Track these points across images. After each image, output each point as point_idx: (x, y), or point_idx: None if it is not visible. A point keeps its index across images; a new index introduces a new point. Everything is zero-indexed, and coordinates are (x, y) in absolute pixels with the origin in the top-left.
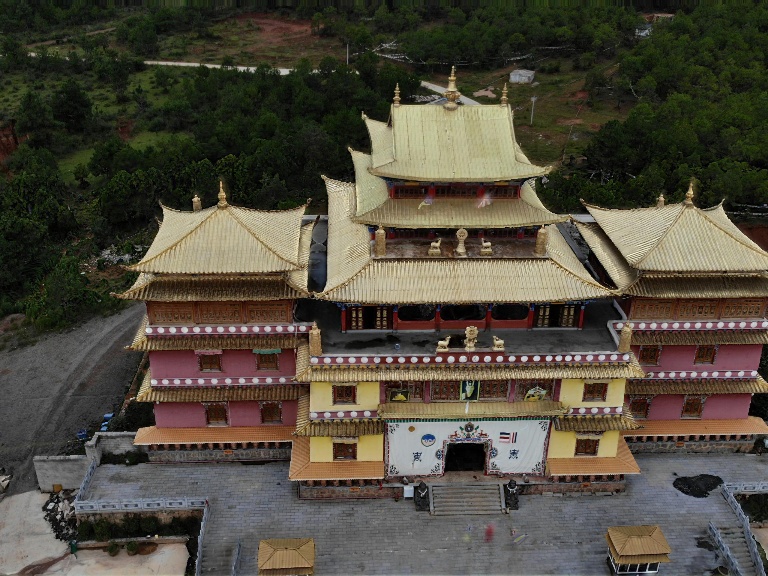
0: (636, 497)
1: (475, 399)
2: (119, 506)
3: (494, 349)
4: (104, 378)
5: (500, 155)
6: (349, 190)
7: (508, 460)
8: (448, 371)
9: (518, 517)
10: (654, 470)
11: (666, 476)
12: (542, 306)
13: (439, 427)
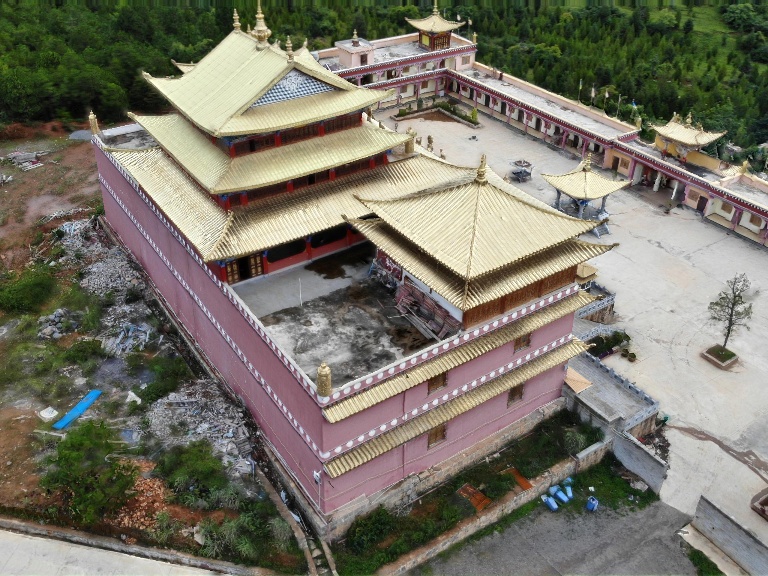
0: None
1: None
2: (627, 385)
3: None
4: (510, 568)
5: (298, 58)
6: (243, 226)
7: None
8: None
9: None
10: None
11: None
12: None
13: None
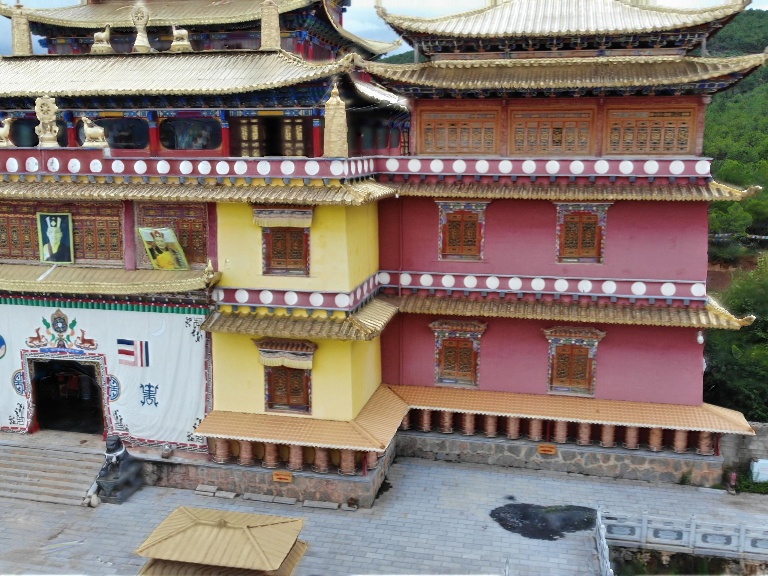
0: (386, 518)
1: (67, 259)
2: None
3: (84, 144)
4: None
5: None
6: None
7: (140, 408)
8: (1, 184)
9: (104, 514)
10: (469, 486)
11: (487, 498)
12: (244, 121)
13: (8, 317)
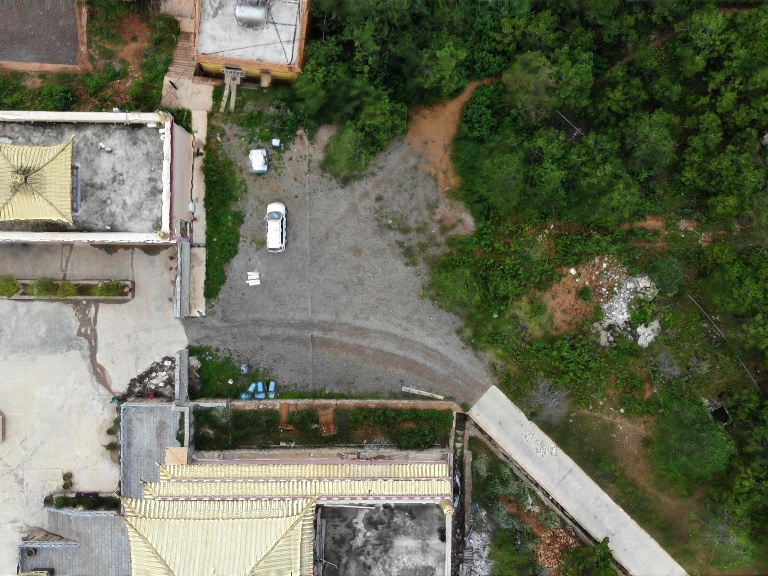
0: None
1: None
2: (123, 440)
3: None
4: (340, 362)
5: None
6: None
7: None
8: None
9: None
10: None
11: None
12: None
13: None
